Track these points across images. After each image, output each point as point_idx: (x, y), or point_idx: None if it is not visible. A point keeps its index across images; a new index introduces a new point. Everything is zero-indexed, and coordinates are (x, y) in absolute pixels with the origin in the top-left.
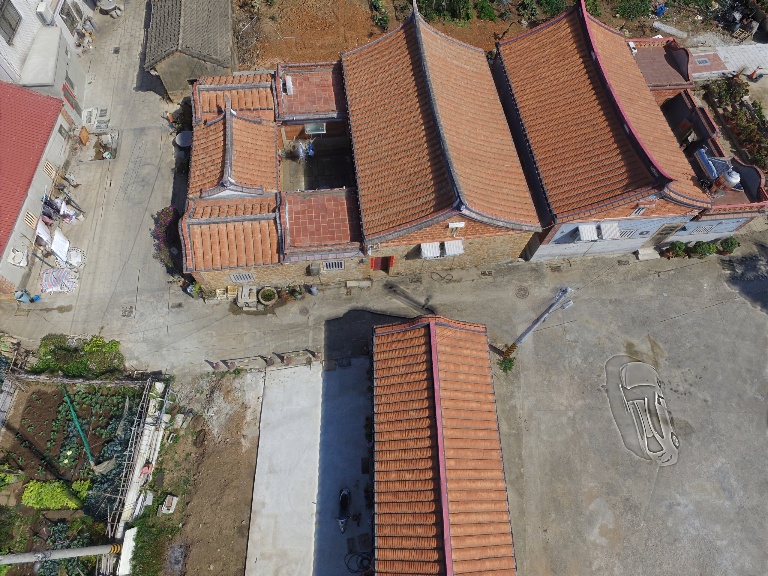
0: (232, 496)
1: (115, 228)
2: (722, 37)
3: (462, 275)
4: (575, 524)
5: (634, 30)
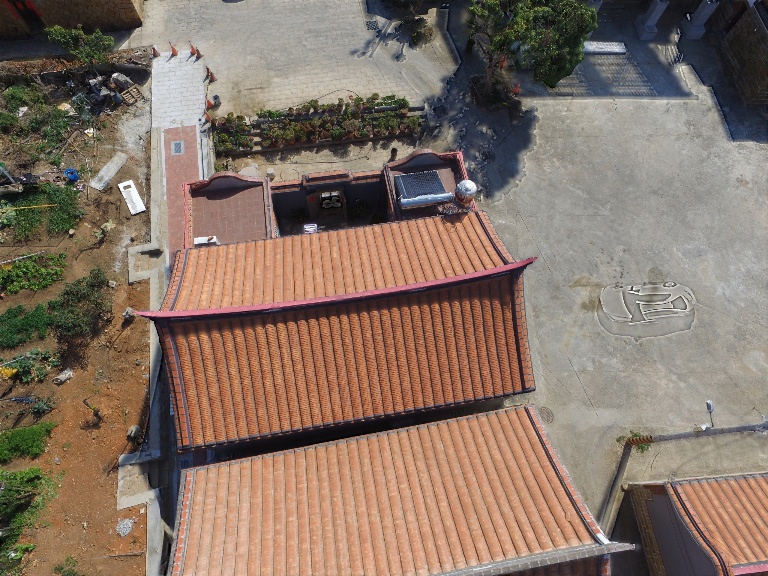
0: None
1: None
2: (130, 115)
3: None
4: None
5: (104, 215)
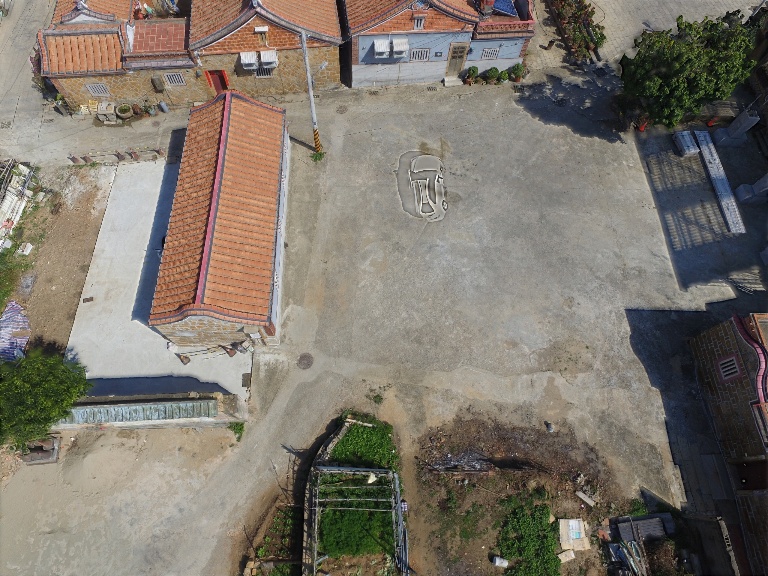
0: (78, 245)
1: (1, 67)
2: None
3: (293, 98)
4: (351, 258)
5: None
